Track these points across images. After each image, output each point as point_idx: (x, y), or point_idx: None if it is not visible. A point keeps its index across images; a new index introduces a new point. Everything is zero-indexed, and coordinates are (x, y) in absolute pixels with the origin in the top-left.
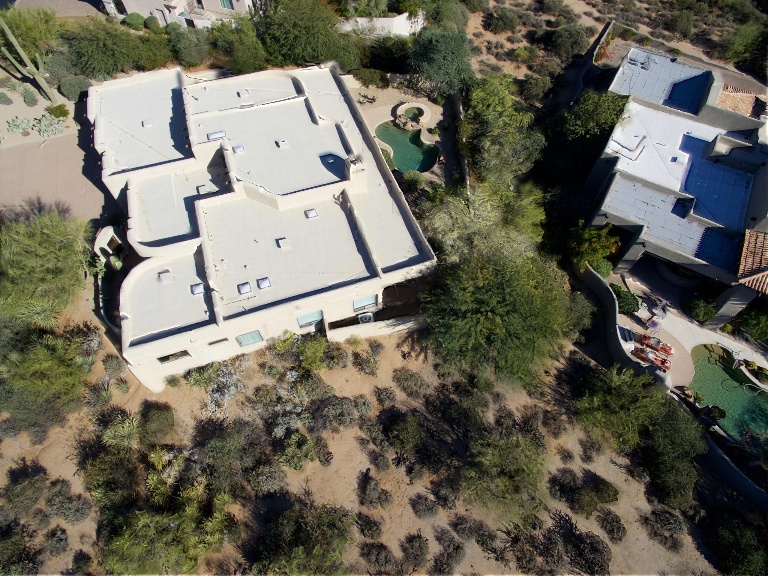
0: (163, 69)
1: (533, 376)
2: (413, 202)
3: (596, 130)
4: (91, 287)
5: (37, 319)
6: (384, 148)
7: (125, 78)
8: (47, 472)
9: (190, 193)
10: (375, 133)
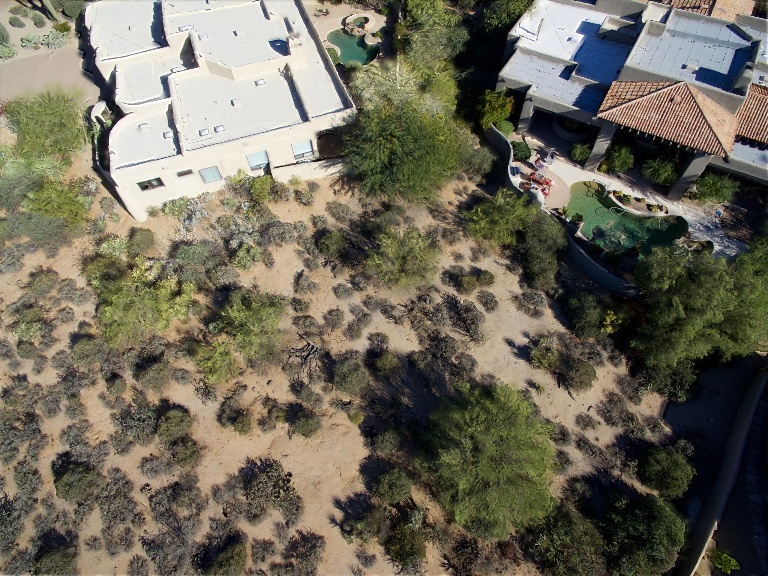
0: None
1: (438, 205)
2: None
3: (506, 20)
4: (90, 150)
5: (49, 173)
6: (333, 48)
7: None
8: (59, 274)
9: (166, 73)
10: (327, 38)
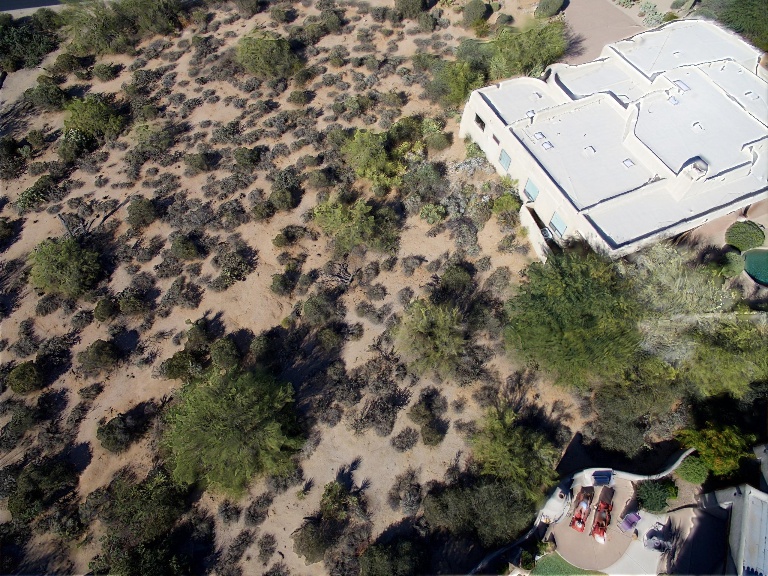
0: (757, 51)
1: (529, 380)
2: (701, 268)
3: None
4: None
5: (494, 68)
6: None
7: (724, 31)
8: (405, 106)
9: (617, 92)
10: None
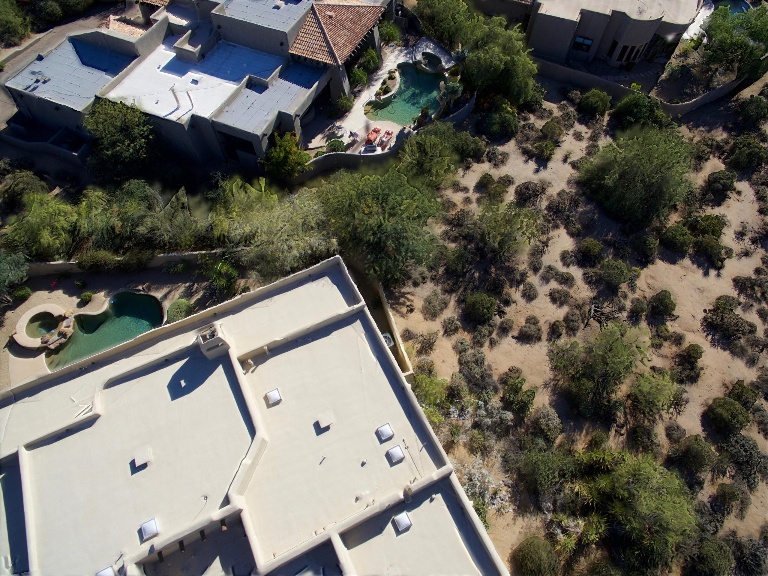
0: None
1: None
2: None
3: (146, 128)
4: None
5: None
6: None
7: None
8: None
9: None
10: None
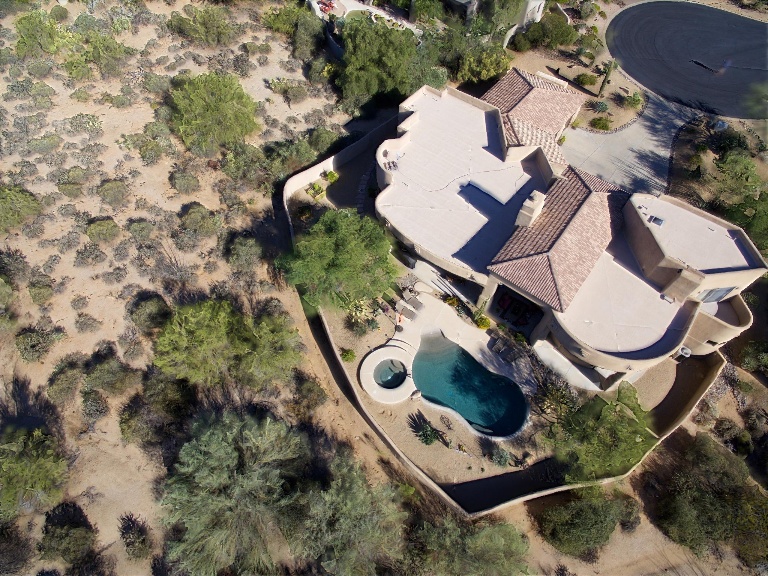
0: None
1: (256, 13)
2: None
3: None
4: None
5: None
6: None
7: None
8: (2, 26)
9: None
10: None
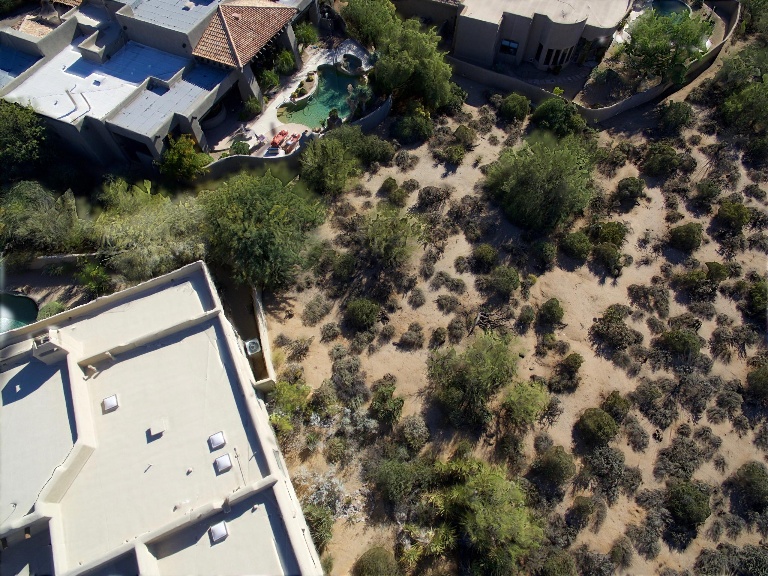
0: None
1: None
2: None
3: (38, 130)
4: None
5: None
6: None
7: None
8: None
9: None
10: None
